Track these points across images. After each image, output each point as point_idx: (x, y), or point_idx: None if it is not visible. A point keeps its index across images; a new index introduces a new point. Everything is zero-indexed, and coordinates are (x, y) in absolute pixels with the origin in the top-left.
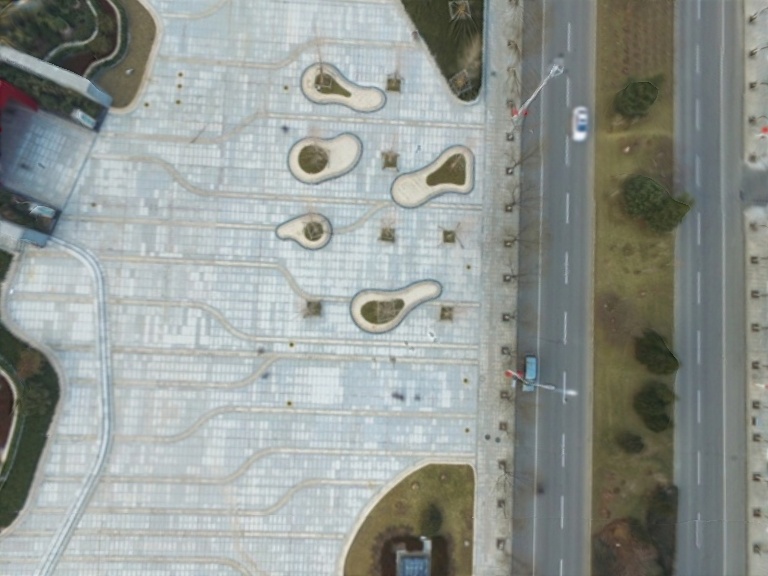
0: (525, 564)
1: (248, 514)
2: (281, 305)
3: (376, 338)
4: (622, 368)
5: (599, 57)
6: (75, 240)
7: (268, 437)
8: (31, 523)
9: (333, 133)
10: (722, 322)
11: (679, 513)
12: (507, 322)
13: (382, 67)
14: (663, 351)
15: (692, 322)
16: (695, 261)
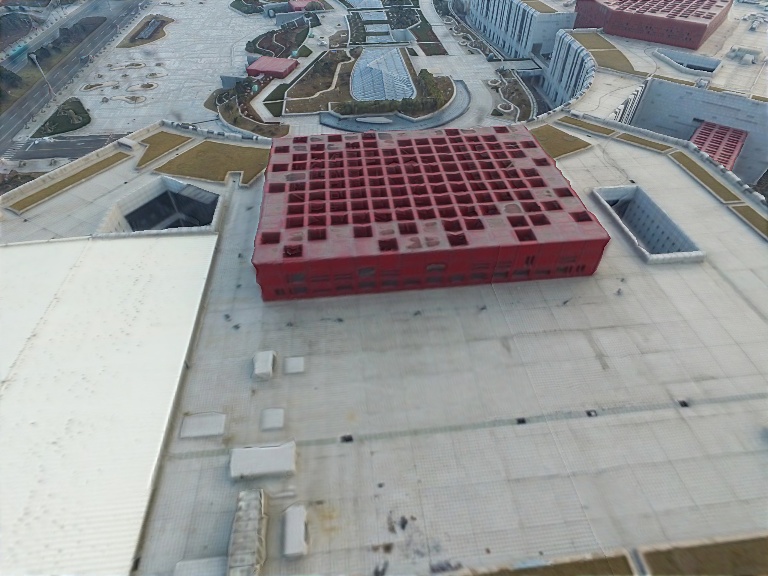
0: None
1: None
2: None
3: None
4: None
5: (3, 112)
6: None
7: None
8: None
9: (137, 91)
10: None
11: None
12: None
13: None
14: None
15: None
16: None
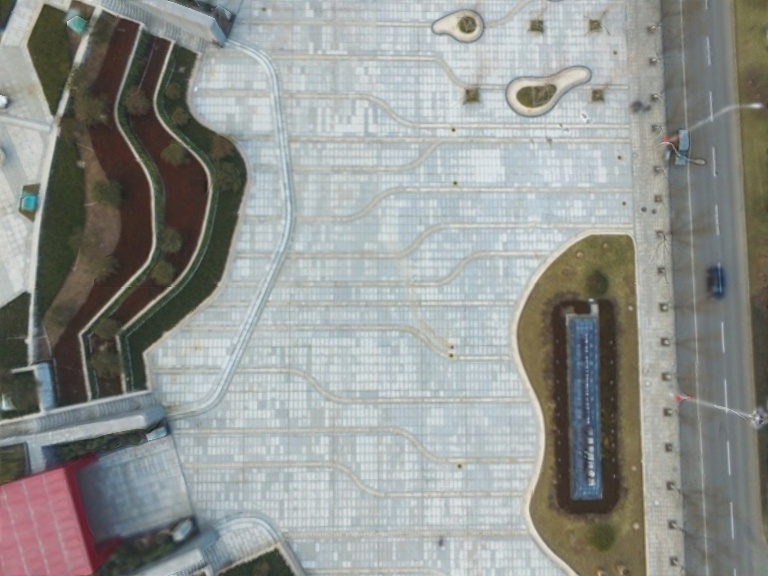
0: (688, 327)
1: (424, 285)
2: (441, 94)
3: (532, 121)
4: None
5: None
6: (249, 42)
7: (438, 214)
8: (228, 295)
9: None
10: None
11: None
12: (657, 100)
13: None
14: None
15: None
16: None
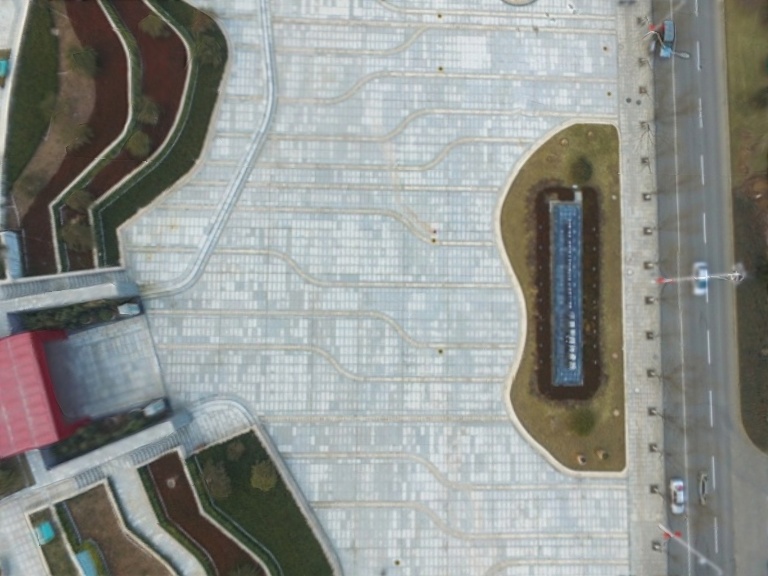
0: (670, 217)
1: (407, 169)
2: None
3: (519, 10)
4: (753, 36)
5: None
6: None
7: (422, 99)
8: (206, 174)
9: None
10: None
11: None
12: None
13: None
14: None
15: None
16: None
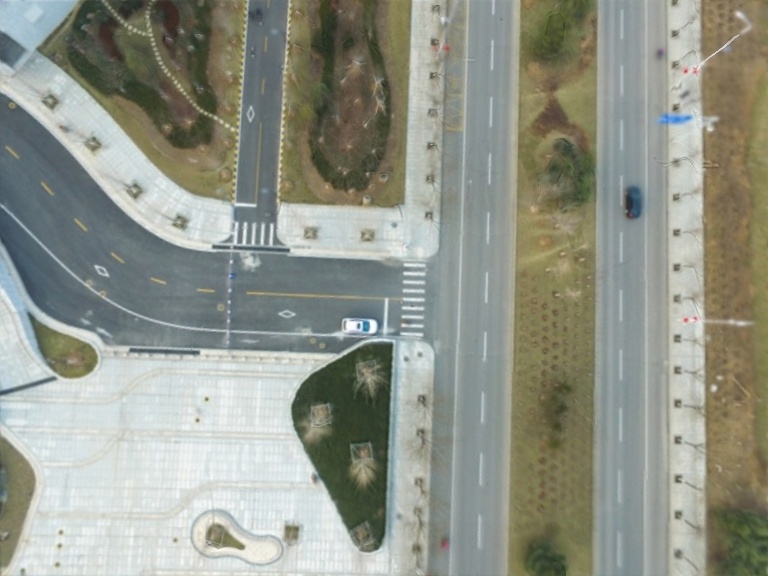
0: None
1: None
2: None
3: None
4: None
5: (512, 492)
6: None
7: None
8: None
9: None
10: None
11: None
12: None
13: (279, 512)
14: None
15: None
16: None
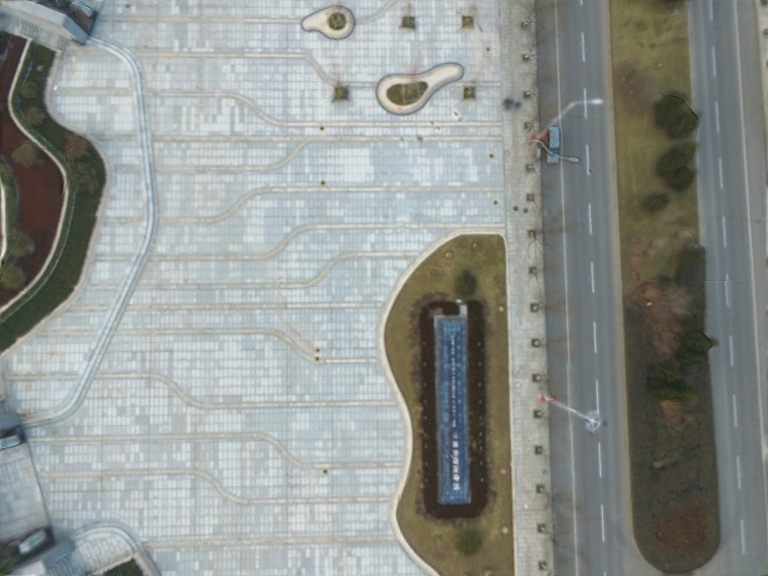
0: (559, 327)
1: (290, 287)
2: (310, 92)
3: (403, 119)
4: (643, 137)
5: None
6: (112, 39)
7: (305, 215)
8: (86, 299)
9: None
10: (739, 92)
11: (707, 271)
12: (528, 97)
13: None
14: (683, 104)
15: (709, 93)
16: (709, 35)
